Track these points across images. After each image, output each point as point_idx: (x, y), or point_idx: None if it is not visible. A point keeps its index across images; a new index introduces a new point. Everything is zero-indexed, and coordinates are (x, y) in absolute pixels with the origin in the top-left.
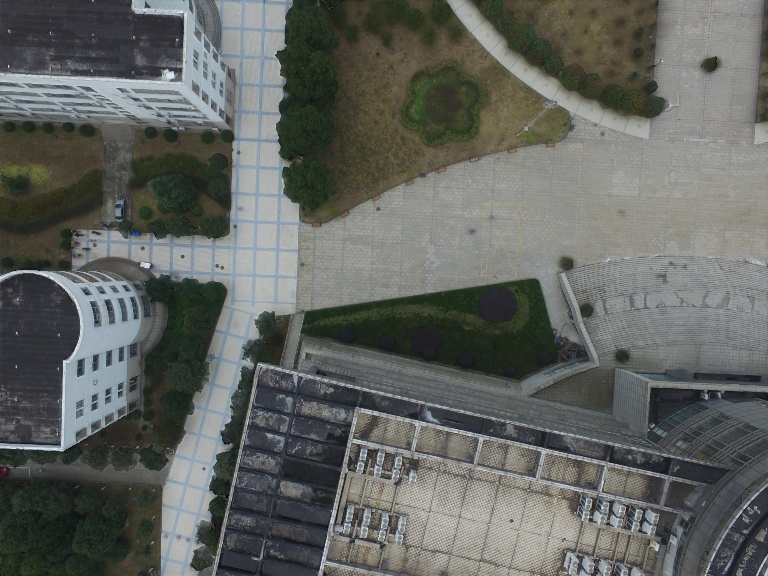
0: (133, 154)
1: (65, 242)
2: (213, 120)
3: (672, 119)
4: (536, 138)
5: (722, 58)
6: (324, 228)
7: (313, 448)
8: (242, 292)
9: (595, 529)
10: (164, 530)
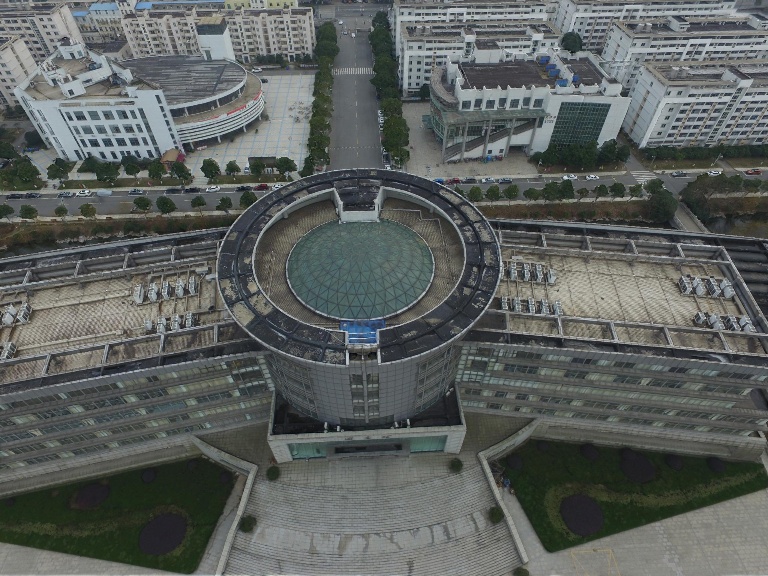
0: None
1: None
2: None
3: None
4: None
5: None
6: None
7: None
8: None
9: None
10: None
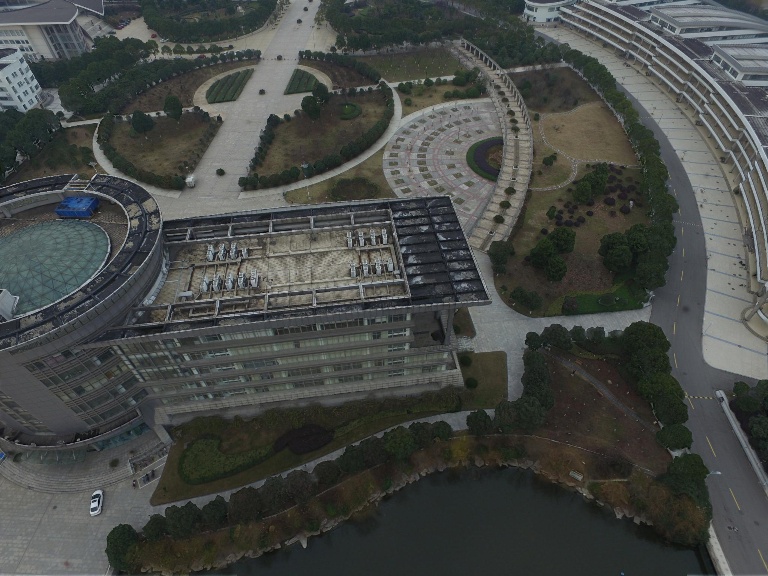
0: None
1: None
2: None
3: (194, 191)
4: None
5: (229, 172)
6: None
7: None
8: None
9: None
10: None
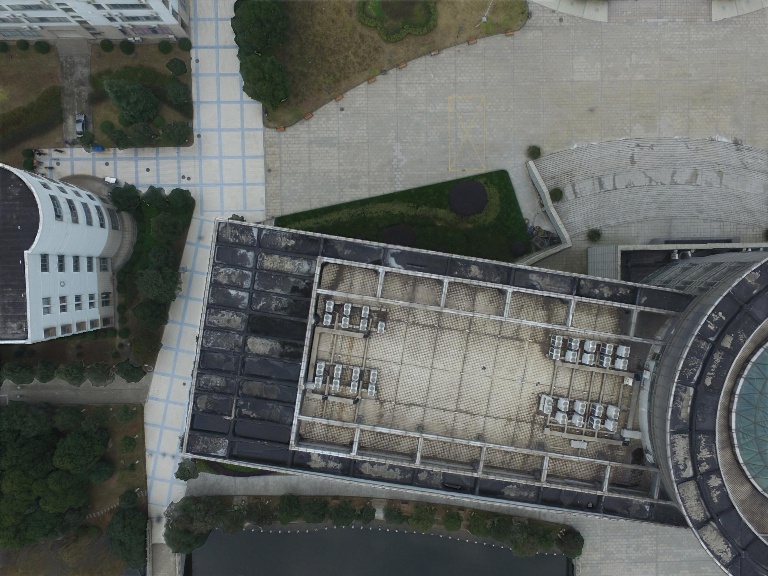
0: (90, 69)
1: (27, 161)
2: (167, 22)
3: (629, 1)
4: (495, 28)
5: None
6: (289, 132)
7: (278, 302)
8: (210, 202)
9: (568, 371)
10: (148, 449)
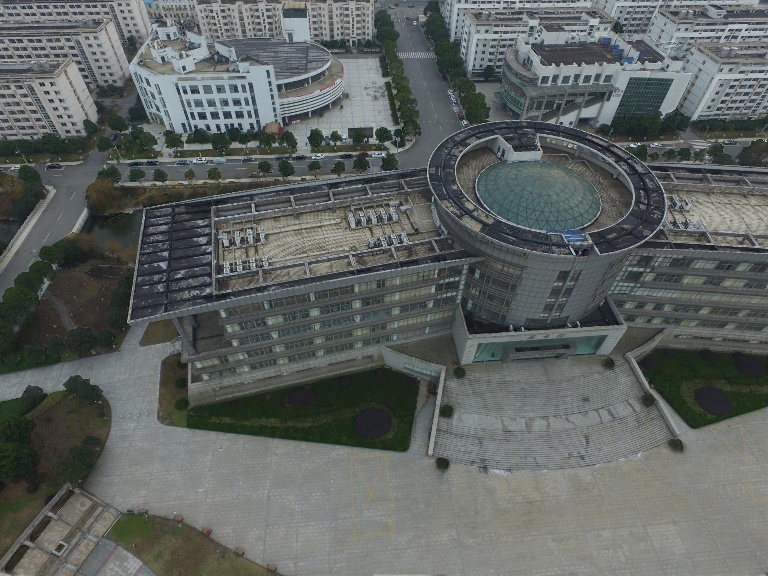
0: None
1: None
2: None
3: None
4: None
5: None
6: None
7: None
8: None
9: None
10: None
